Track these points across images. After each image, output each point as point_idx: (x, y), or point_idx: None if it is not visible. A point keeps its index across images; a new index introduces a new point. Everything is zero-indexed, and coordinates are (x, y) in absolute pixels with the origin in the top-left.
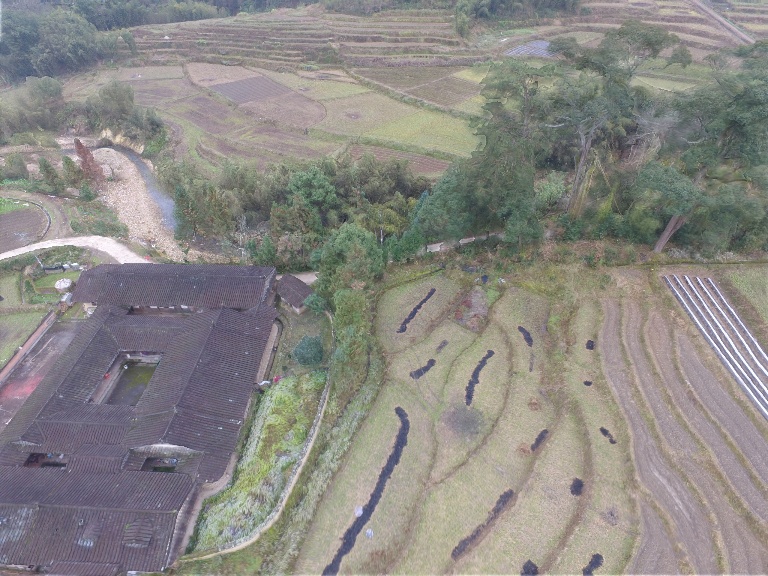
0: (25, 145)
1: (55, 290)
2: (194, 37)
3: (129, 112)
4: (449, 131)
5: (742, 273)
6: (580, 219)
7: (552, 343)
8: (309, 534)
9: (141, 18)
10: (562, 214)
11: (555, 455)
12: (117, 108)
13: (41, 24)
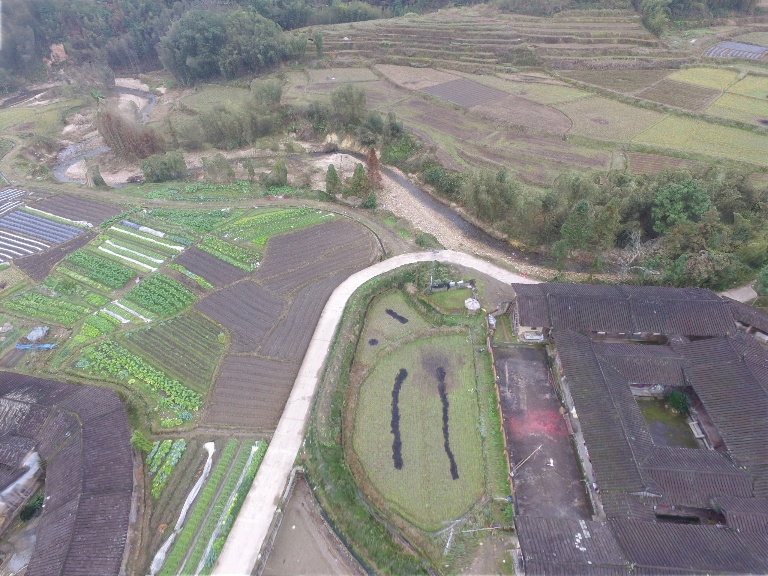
0: (253, 150)
1: (465, 311)
2: (375, 38)
3: (365, 116)
4: (720, 138)
5: None
6: None
7: None
8: None
9: (306, 18)
10: None
11: None
12: (350, 112)
13: (226, 25)
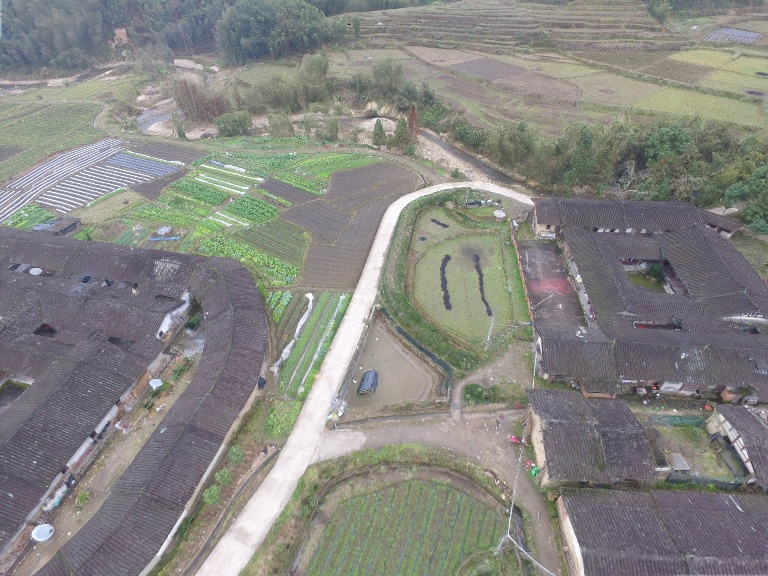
0: (304, 115)
1: (494, 219)
2: (406, 23)
3: (402, 86)
4: (710, 104)
5: None
6: None
7: None
8: None
9: (343, 6)
10: None
11: None
12: (389, 82)
13: (275, 10)
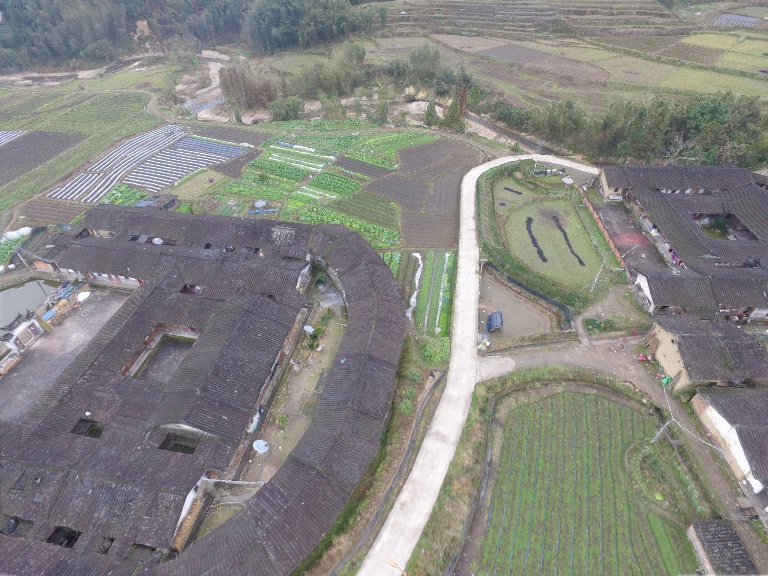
0: (346, 100)
1: (563, 185)
2: (429, 12)
3: (440, 71)
4: (729, 83)
5: None
6: None
7: None
8: None
9: None
10: None
11: None
12: (427, 67)
13: (302, 0)
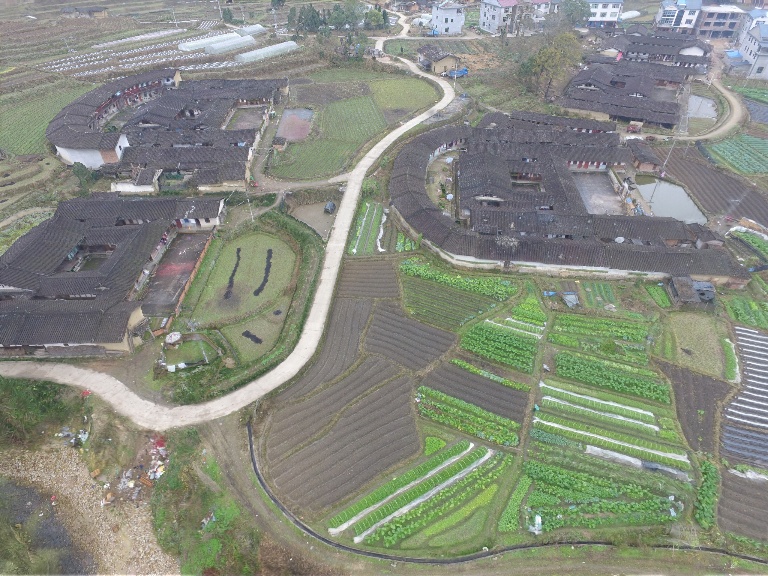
0: None
1: None
2: None
3: None
4: None
5: None
6: None
7: None
8: (5, 207)
9: None
10: None
11: None
12: None
13: None
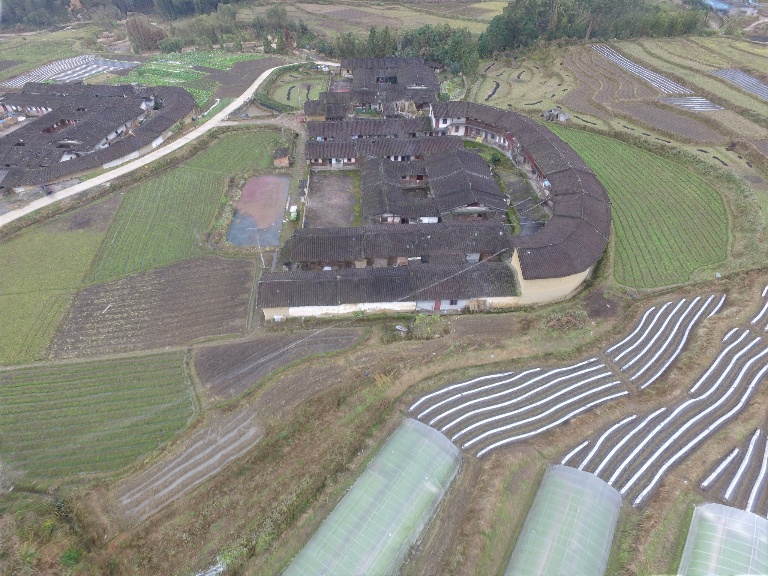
0: None
1: (323, 72)
2: None
3: (286, 22)
4: (478, 27)
5: (618, 43)
6: (555, 31)
7: (547, 68)
8: None
9: None
10: (547, 31)
11: (551, 81)
12: (278, 21)
13: None
